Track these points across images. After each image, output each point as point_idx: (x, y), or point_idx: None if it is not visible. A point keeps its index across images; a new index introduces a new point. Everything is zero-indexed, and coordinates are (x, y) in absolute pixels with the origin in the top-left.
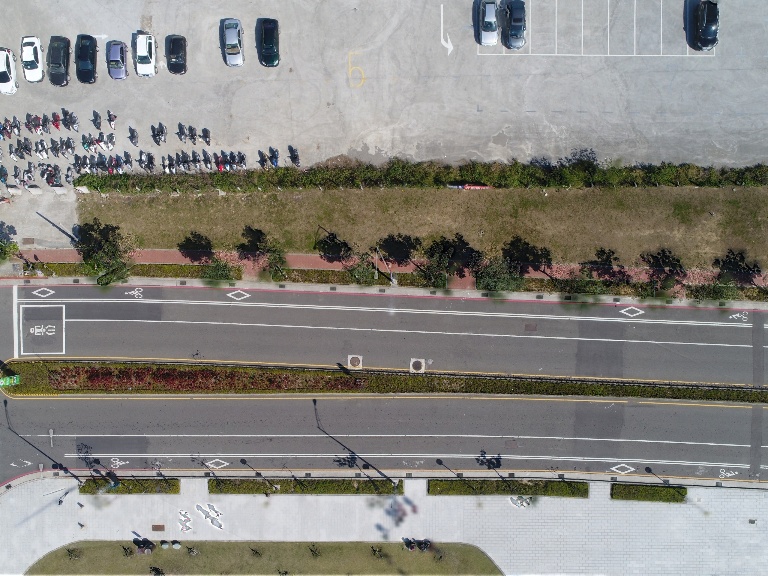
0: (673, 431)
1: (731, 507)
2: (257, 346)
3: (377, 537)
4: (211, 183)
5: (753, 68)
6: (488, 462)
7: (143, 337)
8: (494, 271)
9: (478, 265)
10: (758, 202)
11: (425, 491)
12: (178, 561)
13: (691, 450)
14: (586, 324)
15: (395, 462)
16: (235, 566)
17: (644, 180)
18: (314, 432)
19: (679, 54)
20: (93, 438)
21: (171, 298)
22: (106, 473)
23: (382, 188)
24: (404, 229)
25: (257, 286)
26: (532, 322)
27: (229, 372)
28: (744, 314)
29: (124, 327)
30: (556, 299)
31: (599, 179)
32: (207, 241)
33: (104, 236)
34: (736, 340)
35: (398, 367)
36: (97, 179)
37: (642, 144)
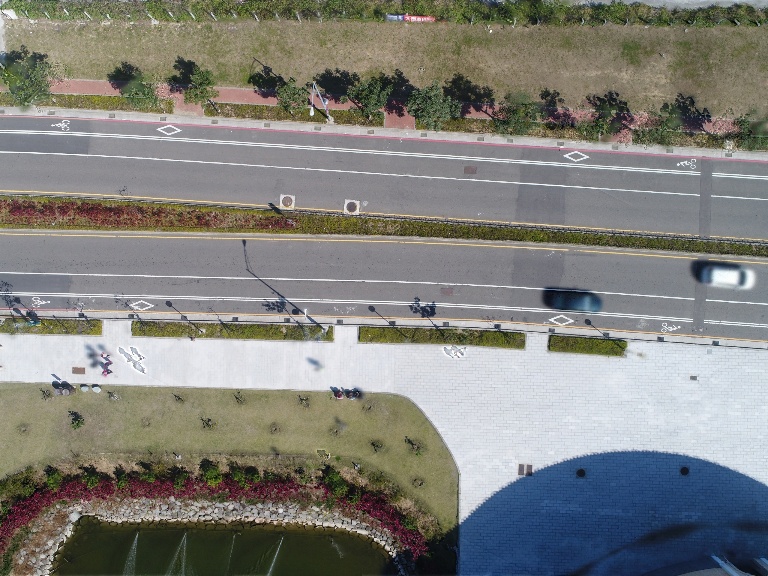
0: (615, 282)
1: (672, 362)
2: (186, 183)
3: (305, 385)
4: (143, 10)
5: None
6: (422, 310)
7: (69, 171)
8: (434, 110)
9: (418, 104)
10: (710, 44)
11: (356, 338)
12: (98, 406)
13: (633, 302)
14: (528, 168)
15: (326, 308)
16: (157, 412)
17: (592, 16)
18: (243, 274)
19: None
20: (14, 275)
21: (99, 131)
22: (26, 313)
23: (320, 20)
24: (342, 64)
25: (188, 121)
26: (472, 165)
27: (156, 209)
28: (692, 161)
29: (49, 160)
30: (498, 141)
31: (545, 14)
32: (138, 72)
33: (31, 64)
34: (683, 188)
35: (332, 208)
36: (25, 3)
37: None
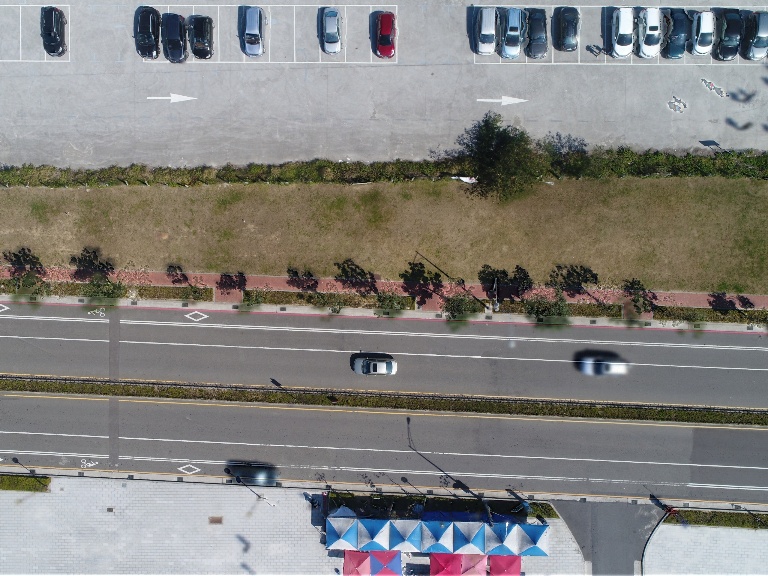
0: (37, 423)
1: (91, 496)
2: None
3: None
4: None
5: (105, 73)
6: None
7: None
8: None
9: None
10: (109, 202)
11: None
12: None
13: (54, 441)
14: None
15: None
16: None
17: None
18: None
19: (37, 59)
20: None
21: None
22: None
23: None
24: None
25: None
26: None
27: None
28: (101, 310)
29: None
30: None
31: None
32: None
33: None
34: (94, 335)
35: None
36: None
37: (5, 146)
